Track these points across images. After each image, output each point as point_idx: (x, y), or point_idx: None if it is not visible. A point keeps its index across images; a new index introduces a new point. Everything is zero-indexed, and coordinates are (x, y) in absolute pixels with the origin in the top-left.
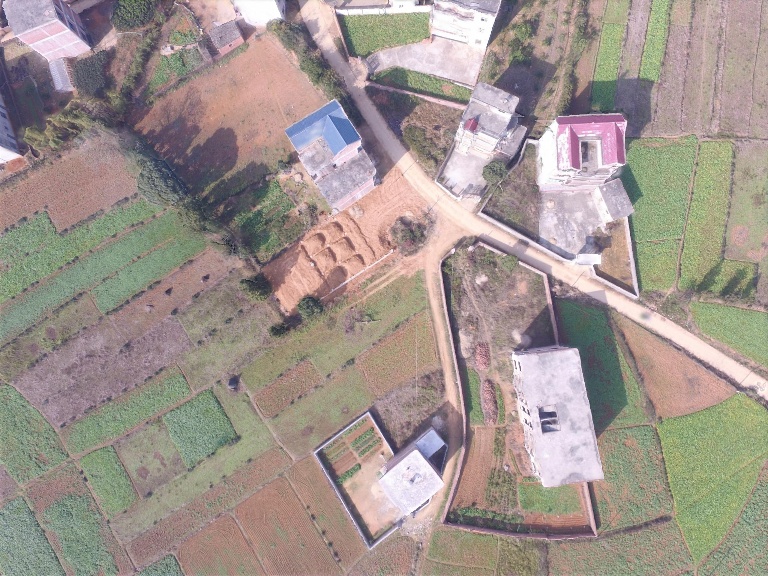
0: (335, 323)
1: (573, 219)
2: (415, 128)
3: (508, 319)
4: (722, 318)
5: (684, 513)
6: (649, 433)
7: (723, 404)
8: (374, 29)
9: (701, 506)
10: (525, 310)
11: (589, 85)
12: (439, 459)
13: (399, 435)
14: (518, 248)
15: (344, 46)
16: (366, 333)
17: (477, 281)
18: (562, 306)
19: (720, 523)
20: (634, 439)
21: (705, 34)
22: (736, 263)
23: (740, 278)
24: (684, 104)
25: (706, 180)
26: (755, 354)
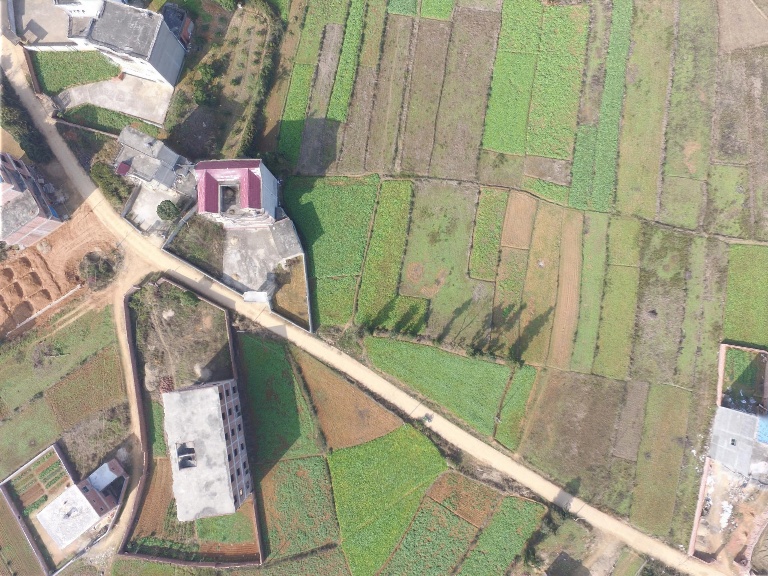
0: (24, 357)
1: (255, 256)
2: (103, 165)
3: (192, 353)
4: (393, 352)
5: (348, 540)
6: (319, 463)
7: (390, 435)
8: (66, 66)
9: (364, 533)
10: (208, 344)
11: (278, 124)
12: (119, 490)
13: (84, 467)
14: (203, 283)
15: (32, 83)
16: (55, 367)
17: (164, 316)
18: (244, 340)
19: (381, 549)
20: (305, 469)
21: (392, 76)
22: (409, 299)
23: (413, 313)
24: (369, 144)
25: (385, 218)
26: (422, 387)
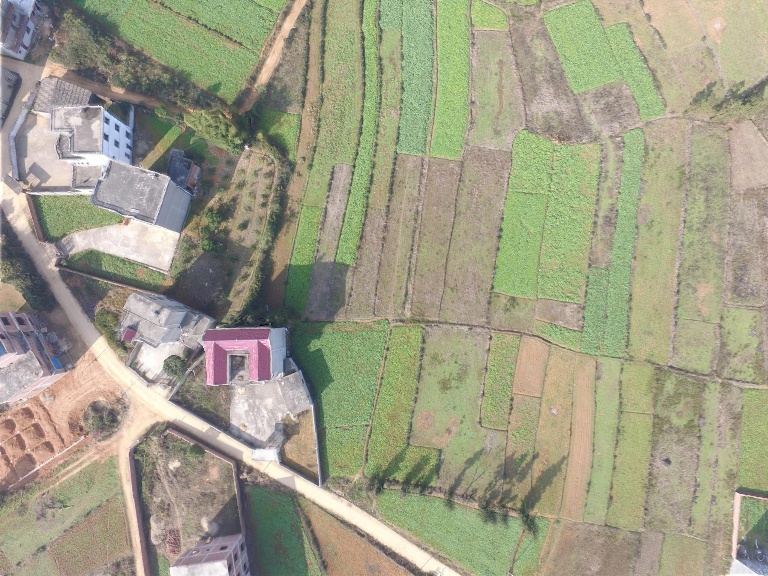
0: (27, 510)
1: (263, 405)
2: (107, 313)
3: (198, 506)
4: (404, 505)
5: None
6: None
7: None
8: (69, 210)
9: None
10: (216, 496)
11: (286, 268)
12: None
13: None
14: (210, 433)
15: (35, 229)
16: (58, 519)
17: (170, 466)
18: (252, 492)
19: None
20: None
21: (402, 217)
22: (420, 449)
23: (423, 464)
24: (378, 288)
25: (395, 365)
26: (434, 541)
